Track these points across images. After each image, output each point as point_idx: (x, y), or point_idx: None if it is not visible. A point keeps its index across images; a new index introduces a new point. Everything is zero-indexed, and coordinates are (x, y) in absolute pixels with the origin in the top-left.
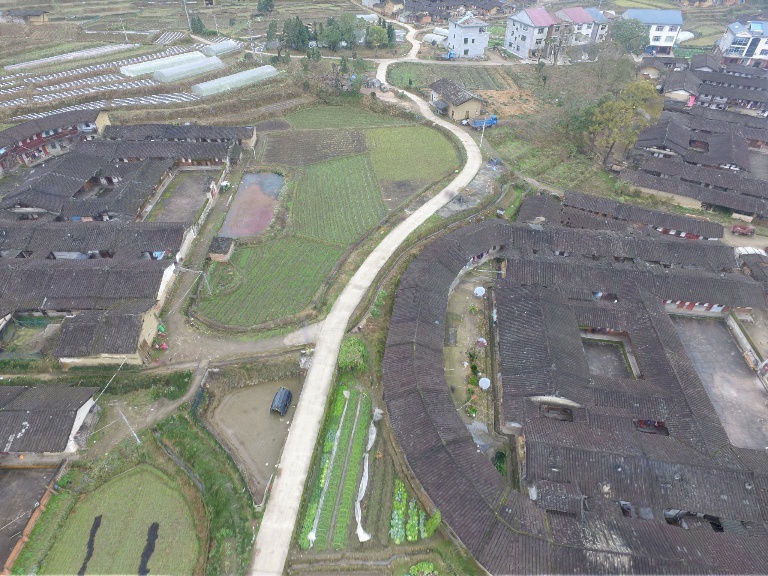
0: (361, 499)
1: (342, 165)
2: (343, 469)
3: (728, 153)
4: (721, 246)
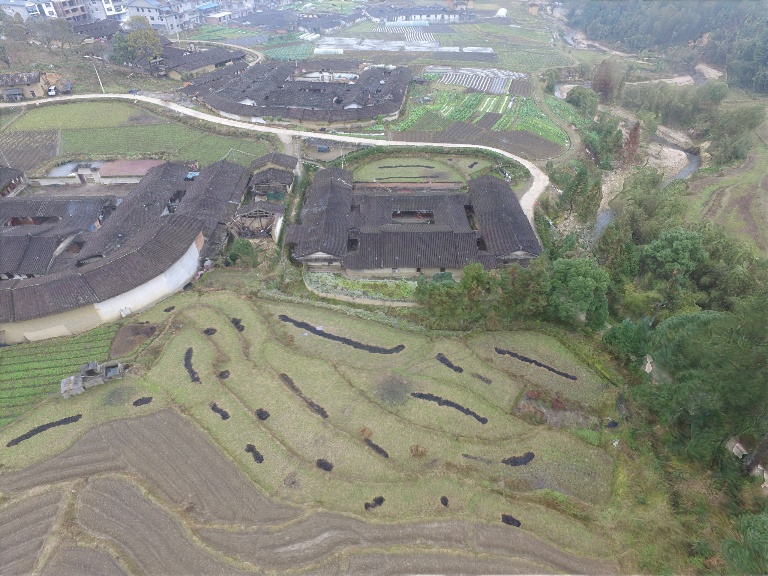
0: None
1: (77, 138)
2: None
3: (175, 49)
4: None
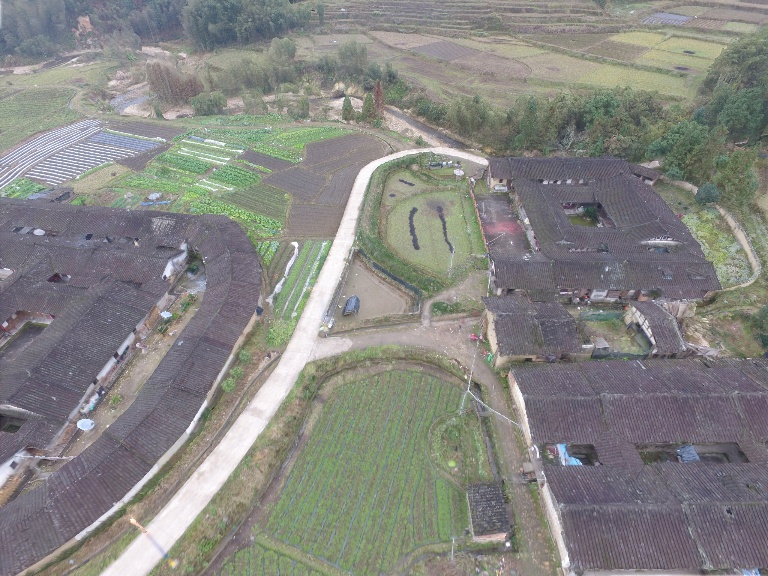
0: (293, 256)
1: None
2: (303, 271)
3: None
4: None
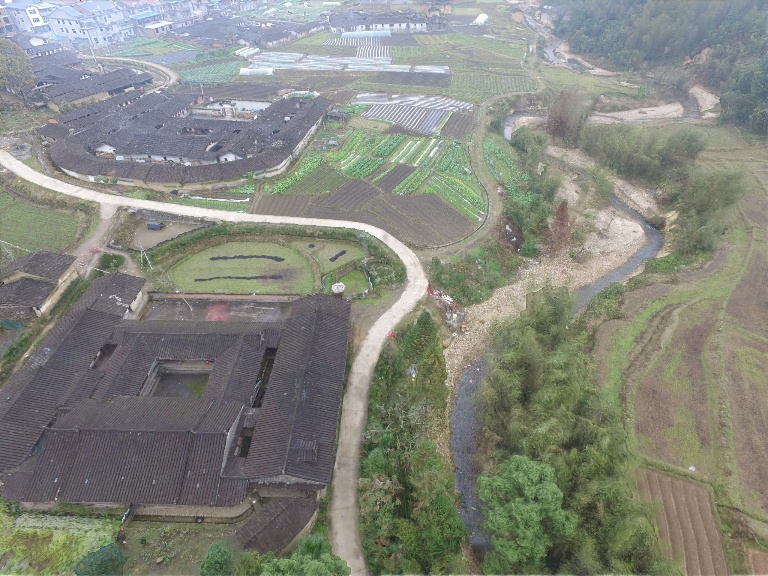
0: None
1: None
2: None
3: (72, 72)
4: (150, 94)
